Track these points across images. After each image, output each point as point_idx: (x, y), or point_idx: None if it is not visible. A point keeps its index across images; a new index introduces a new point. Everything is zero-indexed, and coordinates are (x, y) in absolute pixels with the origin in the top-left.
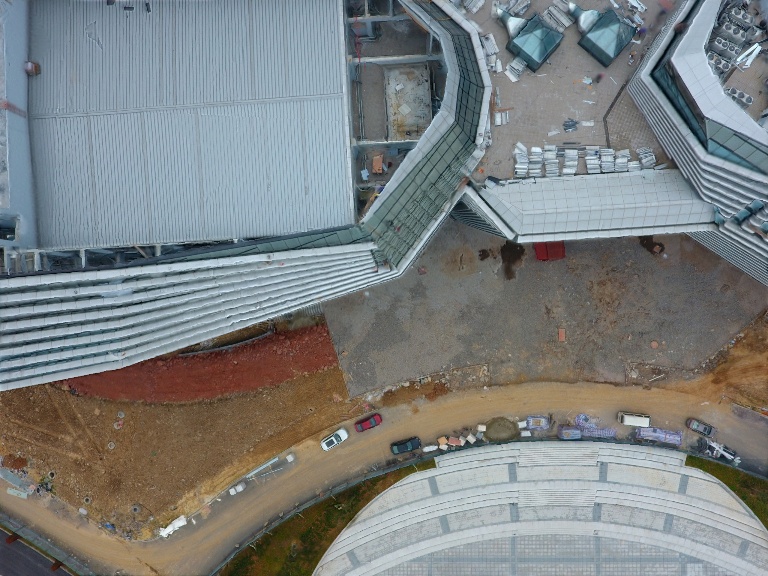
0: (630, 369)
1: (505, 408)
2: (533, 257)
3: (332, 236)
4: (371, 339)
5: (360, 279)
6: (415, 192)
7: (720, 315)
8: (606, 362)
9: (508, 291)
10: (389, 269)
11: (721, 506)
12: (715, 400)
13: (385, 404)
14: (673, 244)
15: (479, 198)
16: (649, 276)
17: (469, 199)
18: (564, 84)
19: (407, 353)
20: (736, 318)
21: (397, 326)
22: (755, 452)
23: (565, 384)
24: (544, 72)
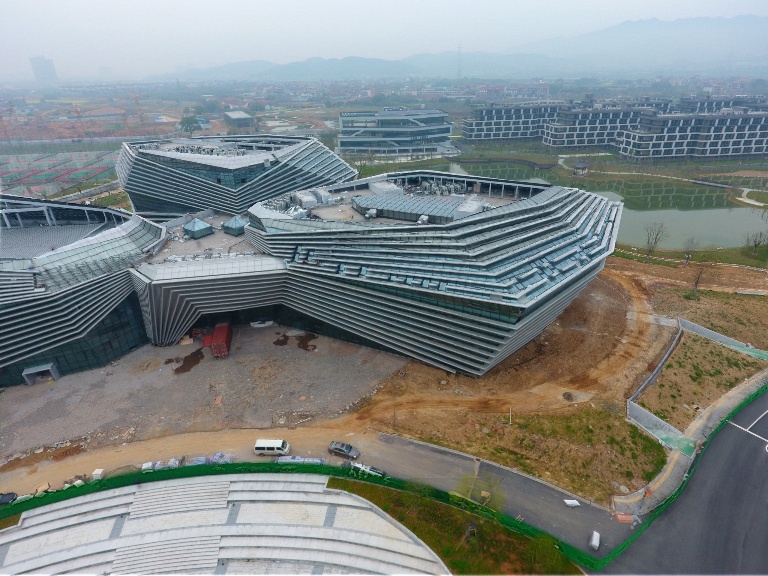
0: (278, 418)
1: (137, 457)
2: (210, 360)
3: (9, 263)
4: (28, 419)
5: (18, 294)
6: (86, 258)
7: (361, 377)
8: (256, 414)
9: (180, 379)
10: (44, 289)
11: (377, 536)
12: (360, 431)
13: (2, 470)
14: (323, 345)
15: (136, 271)
16: (303, 361)
17: (132, 277)
18: (211, 241)
19: (58, 425)
20: (375, 377)
21: (62, 408)
22: (408, 472)
23: (209, 432)
24: (201, 239)
